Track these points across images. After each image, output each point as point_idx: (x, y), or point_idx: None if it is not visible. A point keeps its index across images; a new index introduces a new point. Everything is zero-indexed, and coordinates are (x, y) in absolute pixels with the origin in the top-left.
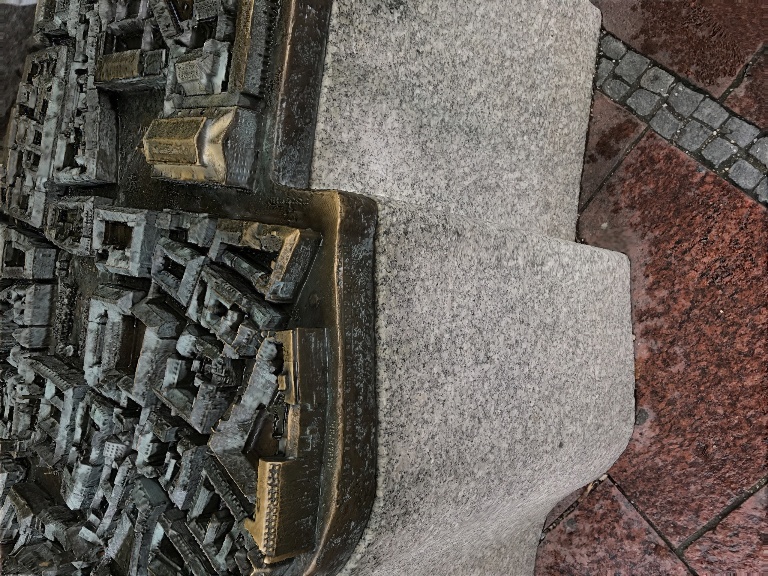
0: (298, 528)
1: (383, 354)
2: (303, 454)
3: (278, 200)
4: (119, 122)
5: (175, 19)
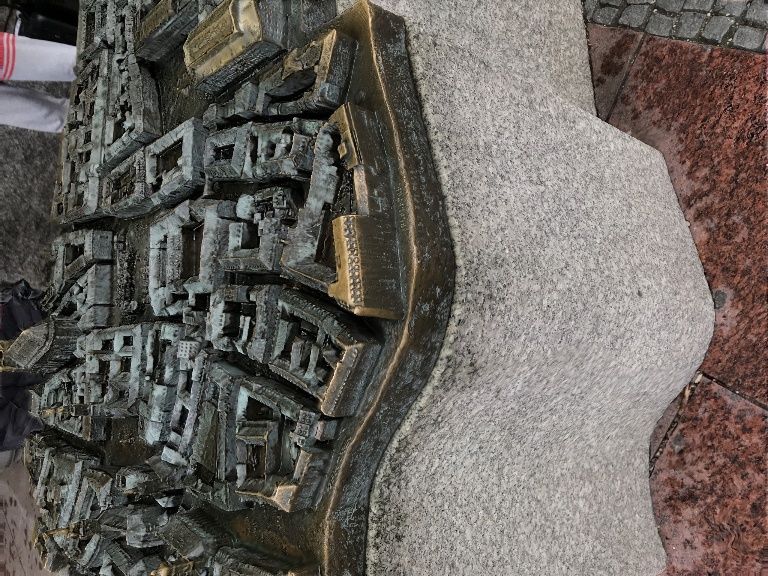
0: (383, 288)
1: (435, 136)
2: (375, 214)
3: None
4: (159, 87)
5: None
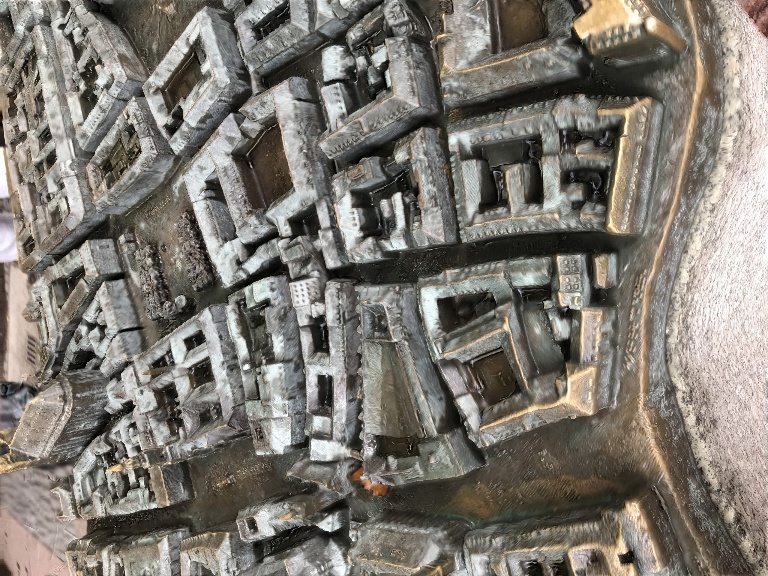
0: None
1: None
2: None
3: None
4: (127, 32)
5: None
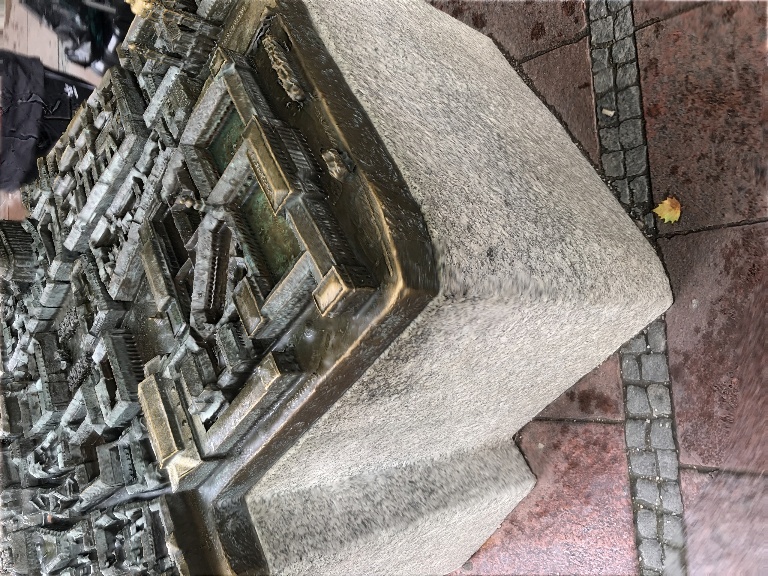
0: None
1: None
2: None
3: (207, 523)
4: None
5: (211, 285)
